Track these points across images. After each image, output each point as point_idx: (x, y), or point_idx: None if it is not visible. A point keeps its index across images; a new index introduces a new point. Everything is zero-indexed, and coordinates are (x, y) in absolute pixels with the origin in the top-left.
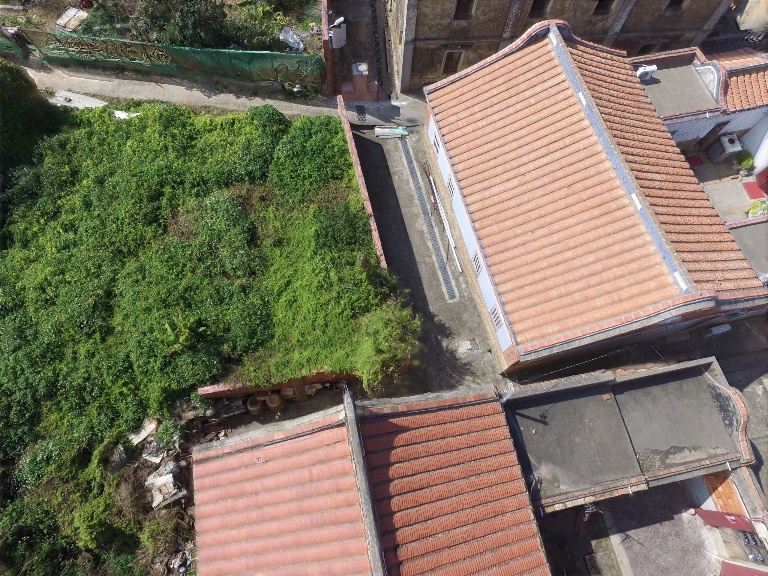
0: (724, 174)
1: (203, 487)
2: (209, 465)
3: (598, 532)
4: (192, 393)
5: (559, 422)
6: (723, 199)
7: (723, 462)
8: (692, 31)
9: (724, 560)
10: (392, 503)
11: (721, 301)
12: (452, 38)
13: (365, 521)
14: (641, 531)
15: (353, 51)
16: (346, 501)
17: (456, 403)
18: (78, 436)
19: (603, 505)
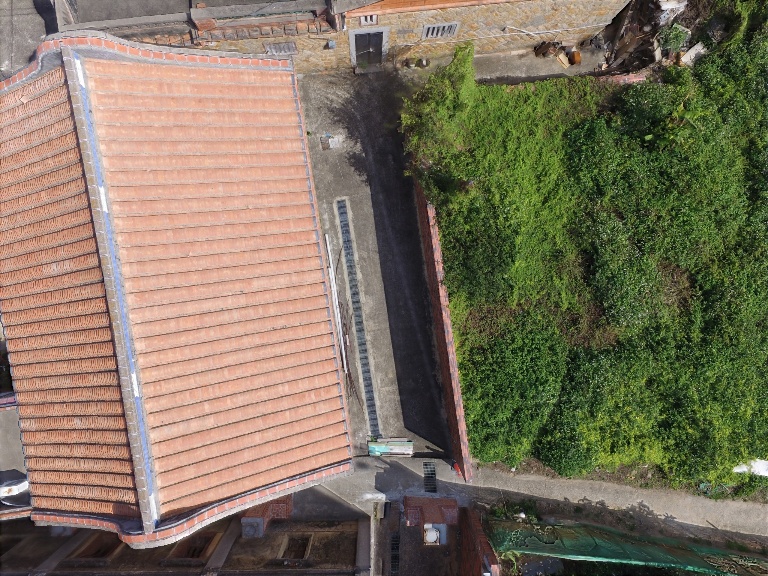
0: None
1: None
2: None
3: None
4: None
5: None
6: None
7: None
8: None
9: None
10: None
11: None
12: (296, 575)
13: None
14: None
15: None
16: None
17: None
18: (764, 42)
19: None
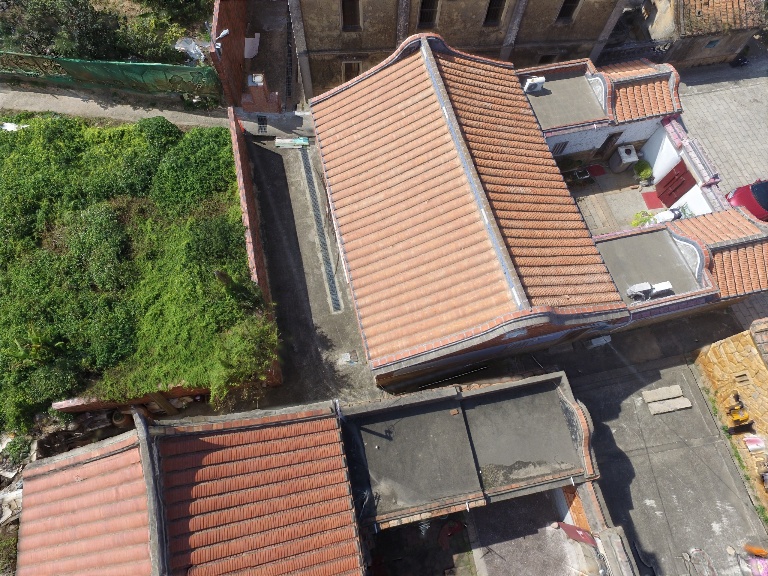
0: (625, 184)
1: (29, 504)
2: (36, 482)
3: (461, 546)
4: (49, 408)
5: (403, 437)
6: (621, 209)
7: (566, 477)
8: (588, 42)
9: (583, 574)
10: (190, 523)
11: (564, 316)
12: (346, 49)
13: (148, 542)
14: (504, 545)
15: (265, 61)
16: (142, 521)
17: (284, 420)
18: None
19: (468, 519)
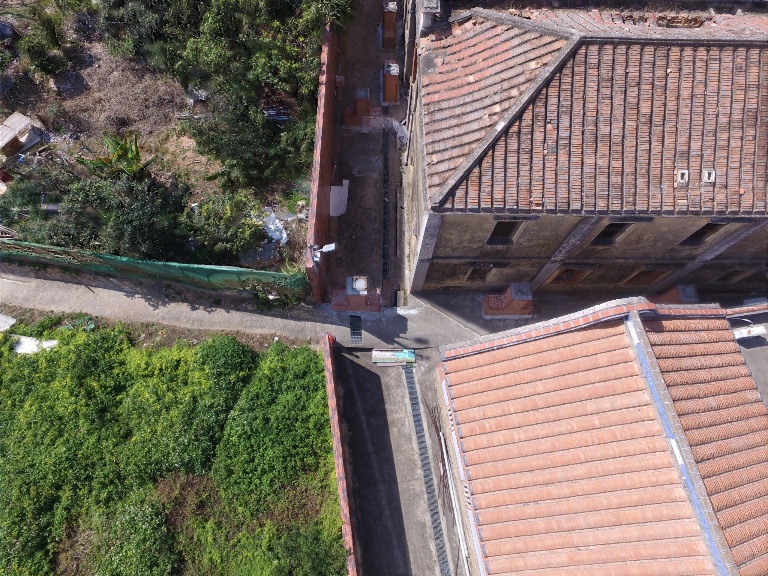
0: None
1: None
2: None
3: None
4: None
5: None
6: None
7: None
8: None
9: None
10: None
11: None
12: (483, 257)
13: None
14: None
15: (355, 221)
16: None
17: None
18: None
19: None
